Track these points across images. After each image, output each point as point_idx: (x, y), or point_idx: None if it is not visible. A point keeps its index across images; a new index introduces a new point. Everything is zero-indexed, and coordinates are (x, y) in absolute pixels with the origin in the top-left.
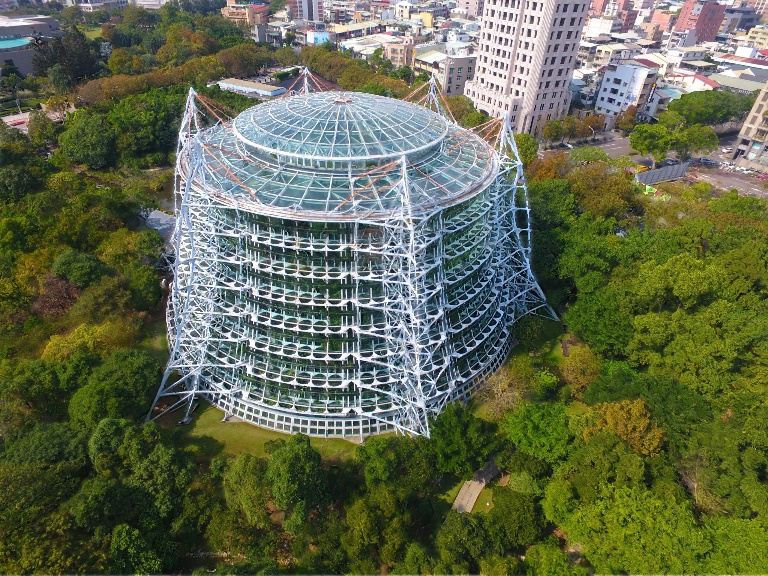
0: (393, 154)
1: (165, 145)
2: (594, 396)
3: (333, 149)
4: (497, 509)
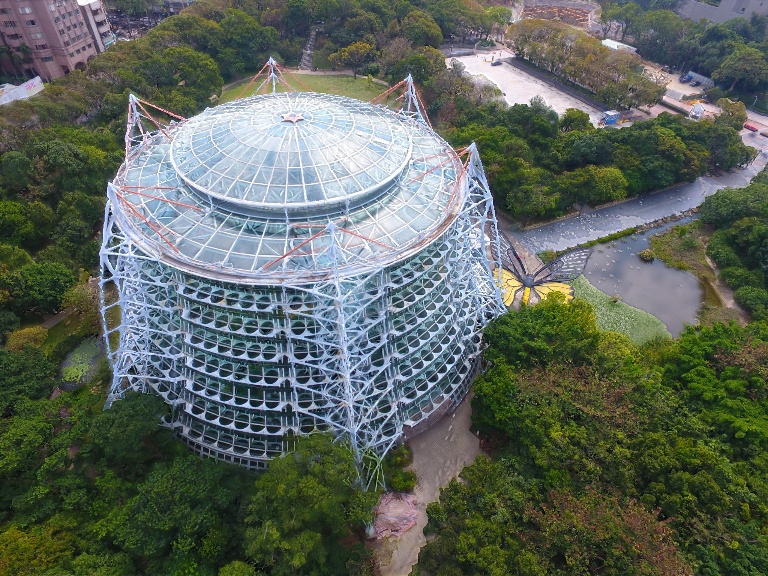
0: (181, 128)
1: (758, 260)
2: (8, 317)
3: (222, 106)
4: (65, 252)
